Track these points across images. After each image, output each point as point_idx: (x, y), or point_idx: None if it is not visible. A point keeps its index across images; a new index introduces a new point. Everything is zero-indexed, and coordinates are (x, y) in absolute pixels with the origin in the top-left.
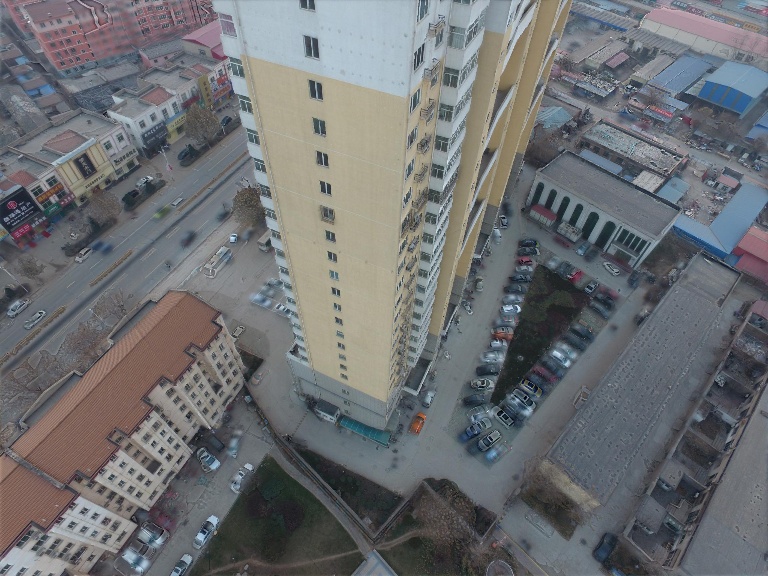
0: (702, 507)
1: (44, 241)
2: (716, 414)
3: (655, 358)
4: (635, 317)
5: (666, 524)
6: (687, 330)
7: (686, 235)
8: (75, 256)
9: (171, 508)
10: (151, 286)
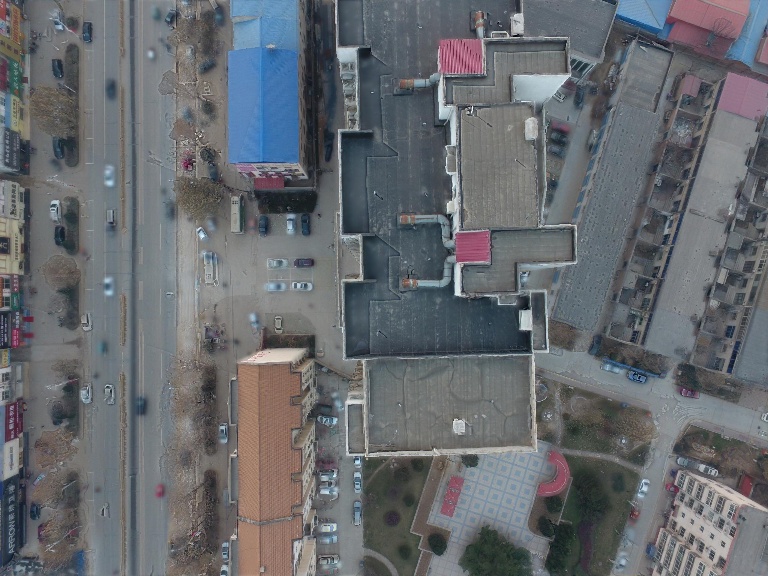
0: (652, 299)
1: (34, 326)
2: (657, 214)
3: (611, 198)
4: (586, 144)
5: (630, 314)
6: (633, 155)
7: (621, 19)
8: (80, 327)
9: (326, 456)
10: (173, 319)
